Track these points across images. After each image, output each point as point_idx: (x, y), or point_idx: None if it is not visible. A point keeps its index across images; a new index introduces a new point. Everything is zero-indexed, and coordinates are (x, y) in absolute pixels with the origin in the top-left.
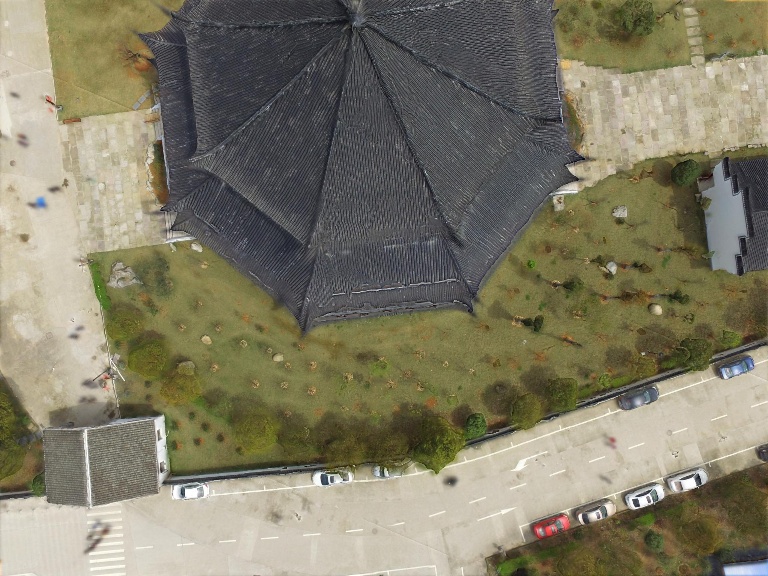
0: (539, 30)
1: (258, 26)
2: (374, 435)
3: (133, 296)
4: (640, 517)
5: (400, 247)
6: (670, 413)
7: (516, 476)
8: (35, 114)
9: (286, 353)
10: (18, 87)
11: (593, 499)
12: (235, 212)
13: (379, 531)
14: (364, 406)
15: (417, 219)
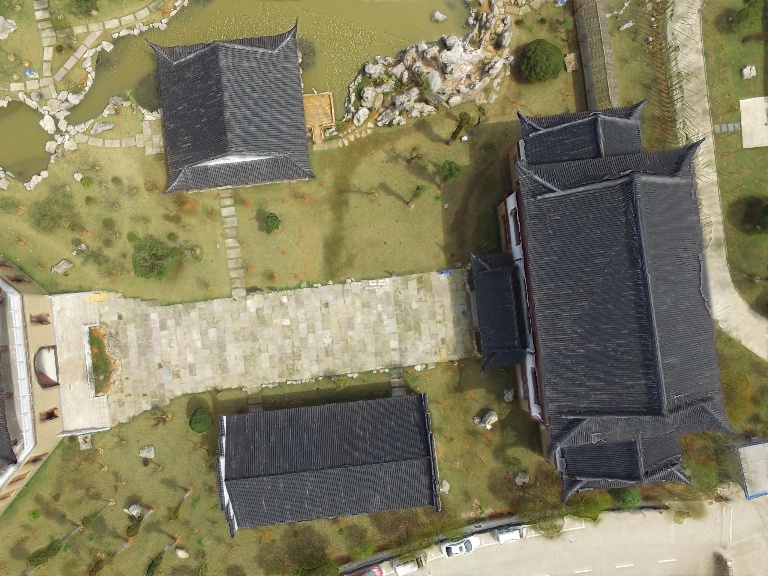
0: None
1: None
2: None
3: None
4: None
5: None
6: None
7: None
8: None
9: None
10: None
11: None
12: None
13: None
14: None
15: None
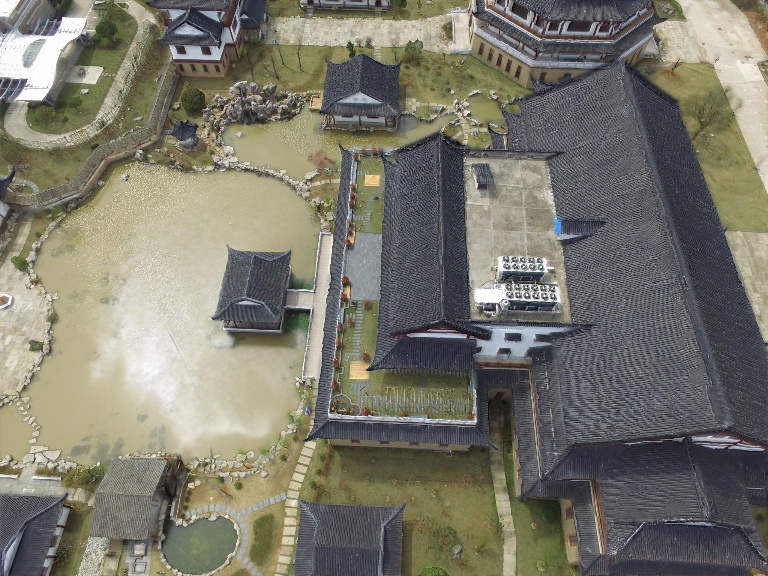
0: None
1: None
2: None
3: None
4: None
5: None
6: None
7: None
8: (725, 67)
9: None
10: (737, 77)
11: None
12: None
13: None
14: None
15: None
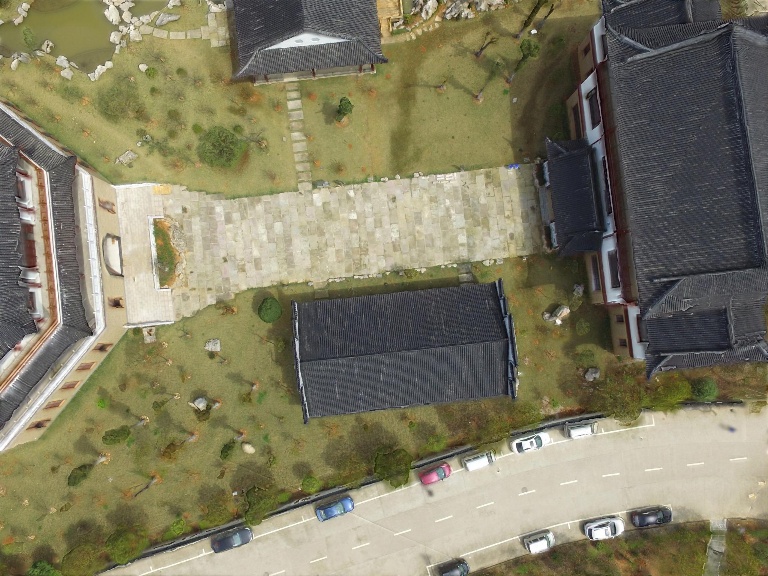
0: None
1: None
2: None
3: None
4: None
5: None
6: (267, 554)
7: None
8: None
9: None
10: None
11: None
12: None
13: None
14: None
15: None
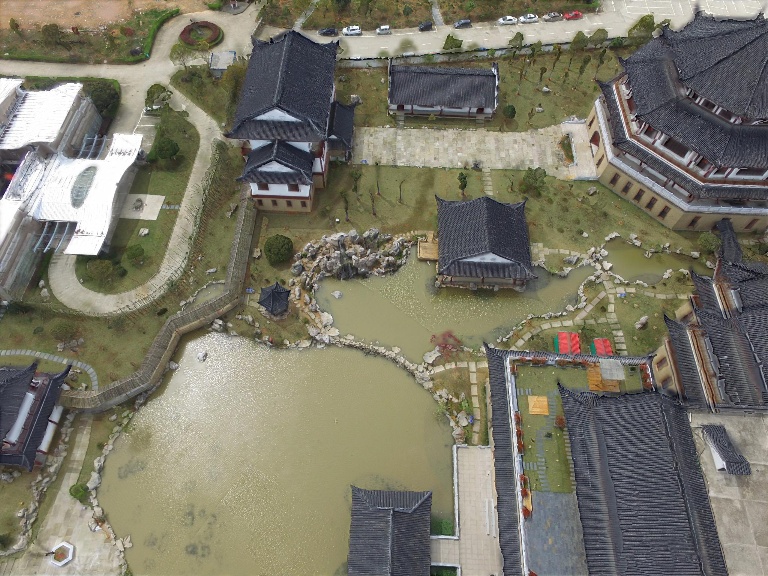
0: (646, 102)
1: None
2: None
3: None
4: None
5: None
6: None
7: (590, 33)
8: None
9: None
10: None
11: None
12: None
13: None
14: None
15: None
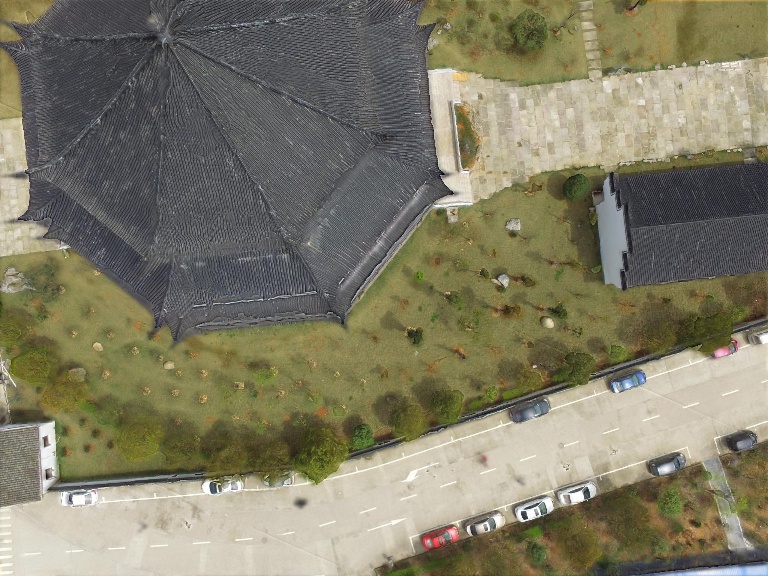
0: (401, 45)
1: (89, 39)
2: (264, 444)
3: (25, 302)
4: (528, 529)
5: (255, 260)
6: (562, 426)
7: (407, 487)
8: None
9: (177, 361)
10: None
11: (483, 511)
12: (92, 222)
13: (269, 540)
14: (254, 415)
15: (260, 233)
